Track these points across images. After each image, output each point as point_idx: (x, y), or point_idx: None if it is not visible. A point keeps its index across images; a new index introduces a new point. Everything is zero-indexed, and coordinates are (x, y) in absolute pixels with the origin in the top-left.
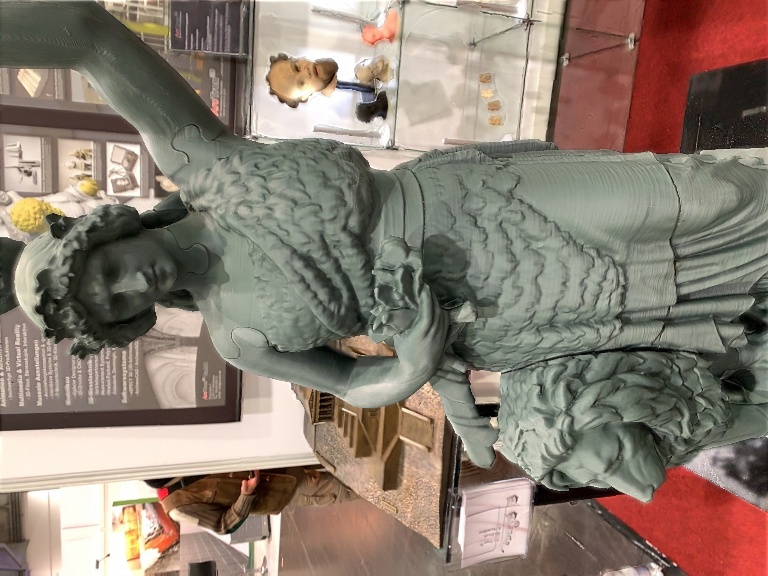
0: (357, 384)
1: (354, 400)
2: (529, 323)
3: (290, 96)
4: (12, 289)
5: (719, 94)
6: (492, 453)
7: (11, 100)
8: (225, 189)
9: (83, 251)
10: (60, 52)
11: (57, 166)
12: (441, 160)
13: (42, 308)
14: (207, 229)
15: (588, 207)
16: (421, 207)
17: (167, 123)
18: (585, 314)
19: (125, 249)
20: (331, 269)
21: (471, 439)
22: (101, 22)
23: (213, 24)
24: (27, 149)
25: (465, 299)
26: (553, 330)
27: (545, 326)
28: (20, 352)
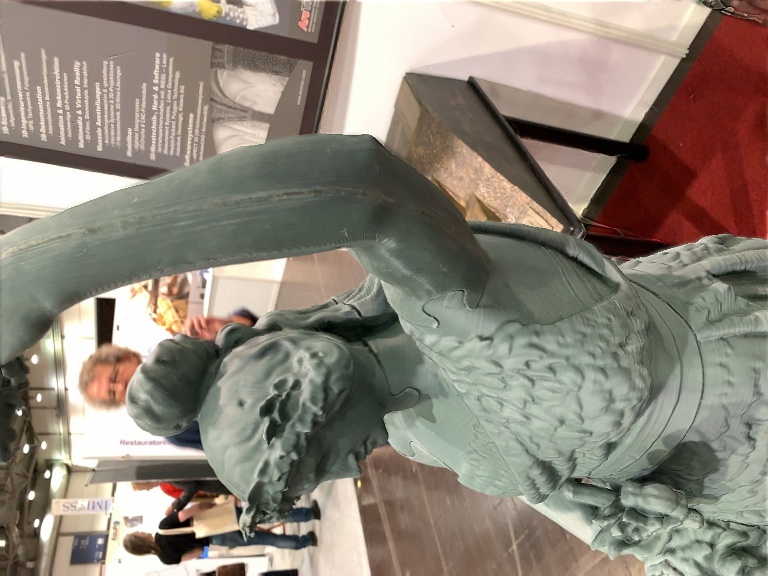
0: None
1: None
2: None
3: None
4: None
5: None
6: None
7: None
8: (475, 372)
9: None
10: None
11: None
12: (739, 331)
13: None
14: (425, 367)
15: None
16: (696, 409)
17: (429, 292)
18: None
19: (340, 431)
20: (565, 468)
21: None
22: (393, 201)
23: None
24: None
25: (689, 492)
26: (758, 513)
27: None
28: (80, 92)
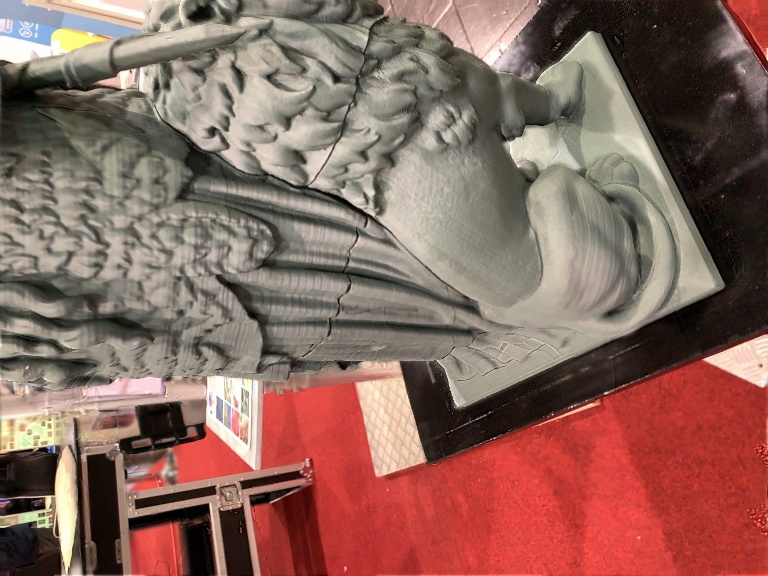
0: None
1: None
2: None
3: None
4: None
5: (429, 418)
6: None
7: None
8: None
9: None
10: None
11: None
12: None
13: None
14: None
15: None
16: None
17: None
18: None
19: None
20: None
21: None
22: None
23: None
24: None
25: None
26: None
27: None
28: None
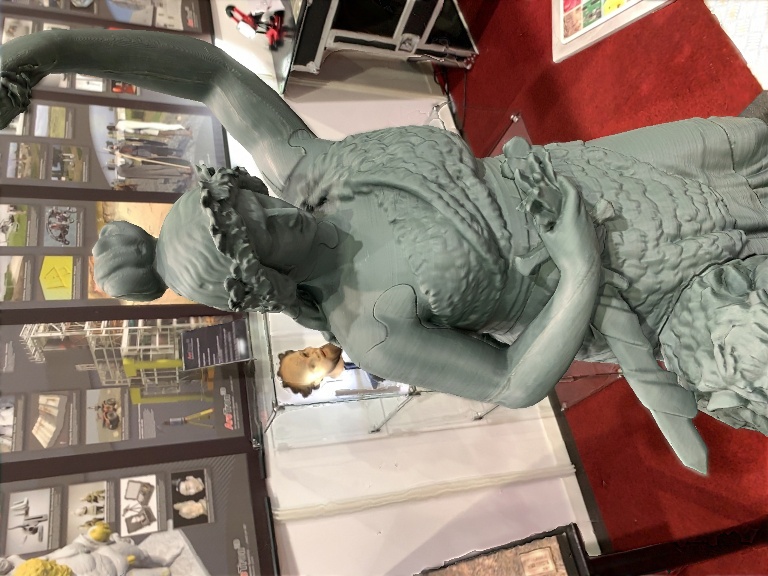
0: (519, 355)
1: (522, 379)
2: (661, 233)
3: (303, 382)
4: (151, 262)
5: None
6: (700, 438)
7: (23, 456)
8: (344, 159)
9: (235, 180)
10: (200, 64)
11: (66, 516)
12: None
13: (207, 205)
14: (329, 216)
15: (652, 141)
16: None
17: (283, 126)
18: (706, 223)
19: None
20: (462, 195)
21: (669, 408)
22: None
23: (222, 341)
24: (34, 505)
25: None
26: (687, 239)
27: (677, 240)
28: None
